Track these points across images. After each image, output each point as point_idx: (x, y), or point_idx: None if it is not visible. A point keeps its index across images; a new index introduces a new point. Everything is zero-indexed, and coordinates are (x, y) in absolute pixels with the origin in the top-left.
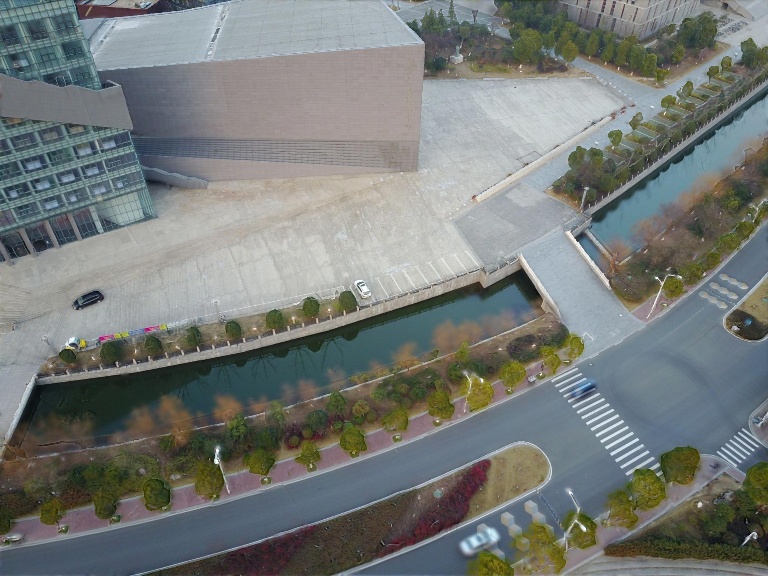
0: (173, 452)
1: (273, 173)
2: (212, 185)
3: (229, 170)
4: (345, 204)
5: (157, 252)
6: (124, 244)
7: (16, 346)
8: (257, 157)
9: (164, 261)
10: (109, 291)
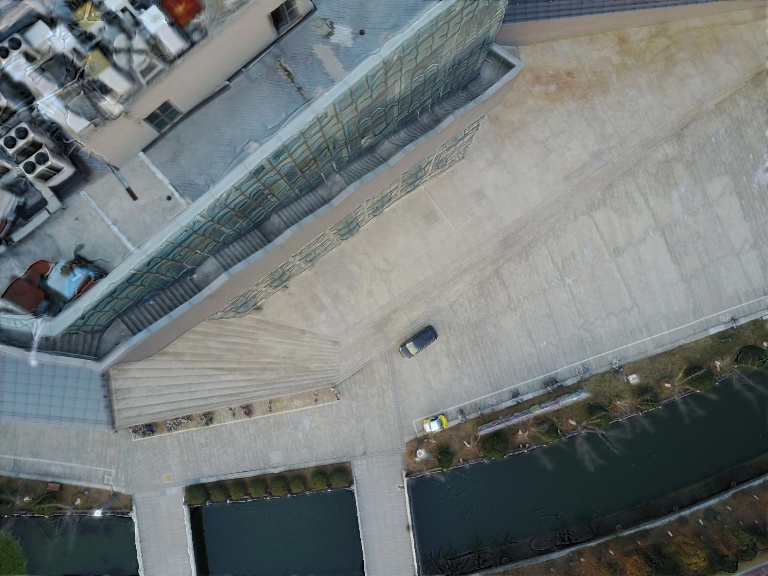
0: (614, 575)
1: (636, 21)
2: (527, 56)
3: (563, 29)
4: (763, 93)
5: (490, 242)
6: (433, 228)
7: (354, 425)
8: (622, 3)
9: (501, 254)
10: (438, 317)
